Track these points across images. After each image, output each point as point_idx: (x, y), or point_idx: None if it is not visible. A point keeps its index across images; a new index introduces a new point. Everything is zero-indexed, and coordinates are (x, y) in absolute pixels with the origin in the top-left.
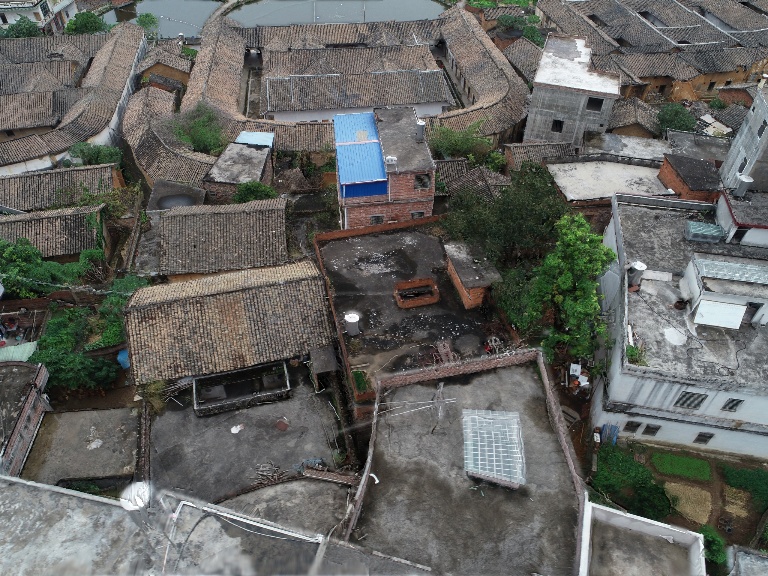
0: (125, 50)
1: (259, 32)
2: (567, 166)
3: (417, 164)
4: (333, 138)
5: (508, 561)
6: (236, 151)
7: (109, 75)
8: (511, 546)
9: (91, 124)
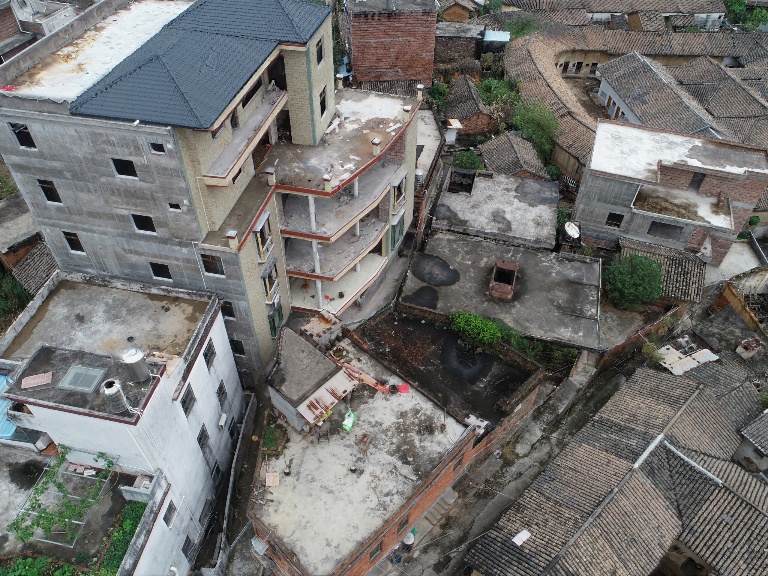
0: (664, 5)
1: (764, 56)
2: (430, 120)
3: (355, 8)
4: (520, 69)
5: (69, 1)
6: (474, 27)
7: (608, 1)
8: (74, 2)
9: (527, 2)
